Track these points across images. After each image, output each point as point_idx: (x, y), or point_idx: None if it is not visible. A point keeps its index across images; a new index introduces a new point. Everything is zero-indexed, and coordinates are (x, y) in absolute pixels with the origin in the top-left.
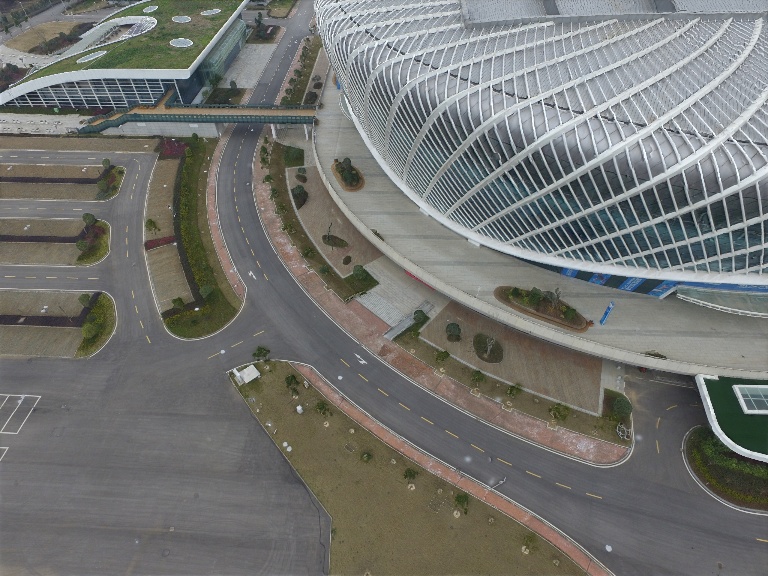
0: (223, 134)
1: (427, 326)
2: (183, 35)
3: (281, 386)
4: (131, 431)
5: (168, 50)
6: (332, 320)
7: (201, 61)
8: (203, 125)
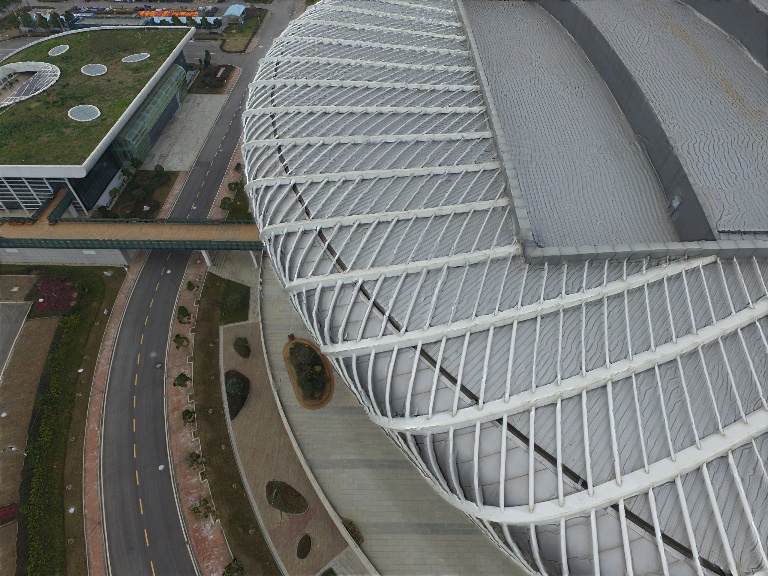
0: (136, 258)
1: None
2: (90, 98)
3: None
4: None
5: (63, 126)
6: None
7: (108, 145)
8: (103, 251)
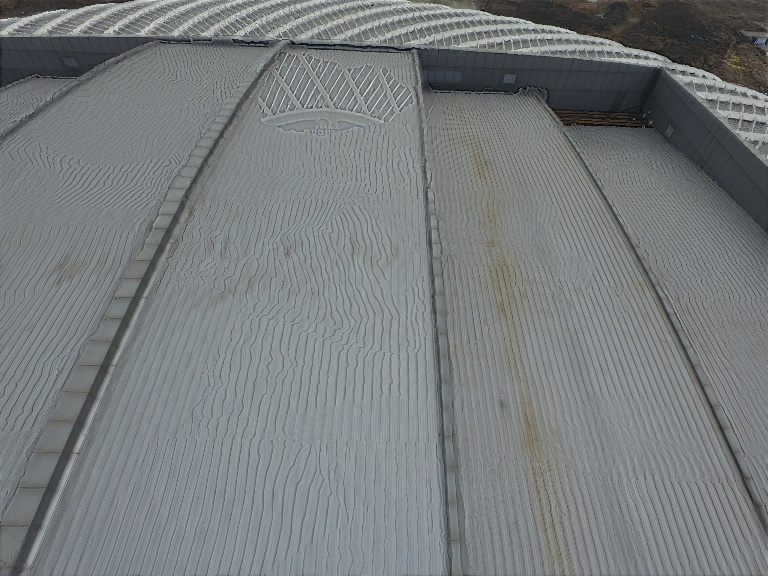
0: None
1: None
2: None
3: None
4: None
5: None
6: None
7: None
8: None
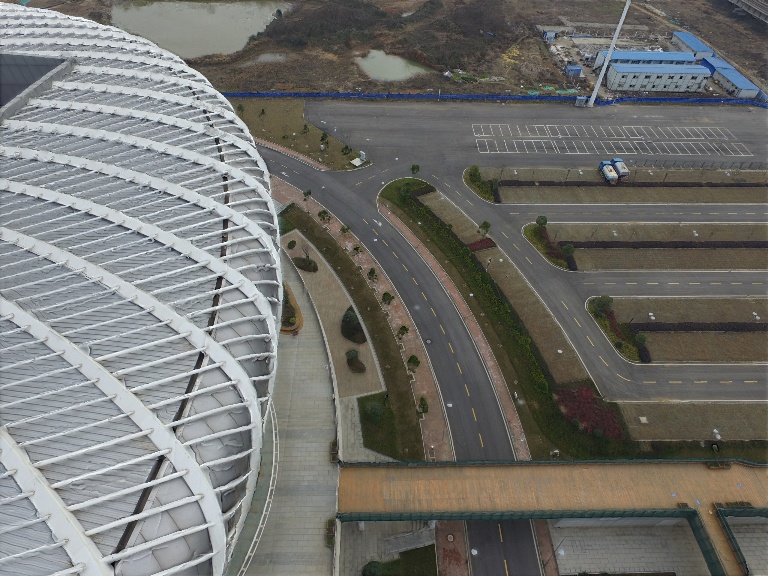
0: None
1: None
2: None
3: (336, 158)
4: (415, 141)
5: None
6: None
7: None
8: None
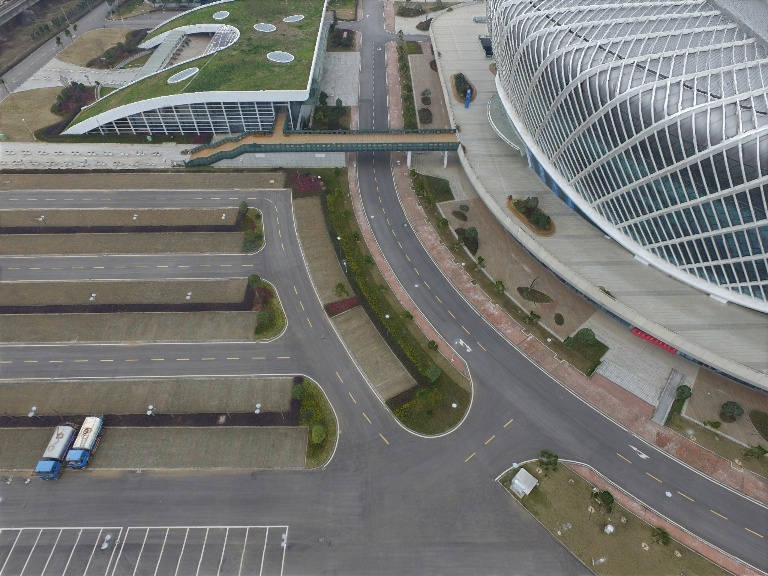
0: (349, 163)
1: (689, 402)
2: (277, 47)
3: (569, 496)
4: (420, 571)
5: (270, 66)
6: (583, 401)
7: None
8: (331, 154)
